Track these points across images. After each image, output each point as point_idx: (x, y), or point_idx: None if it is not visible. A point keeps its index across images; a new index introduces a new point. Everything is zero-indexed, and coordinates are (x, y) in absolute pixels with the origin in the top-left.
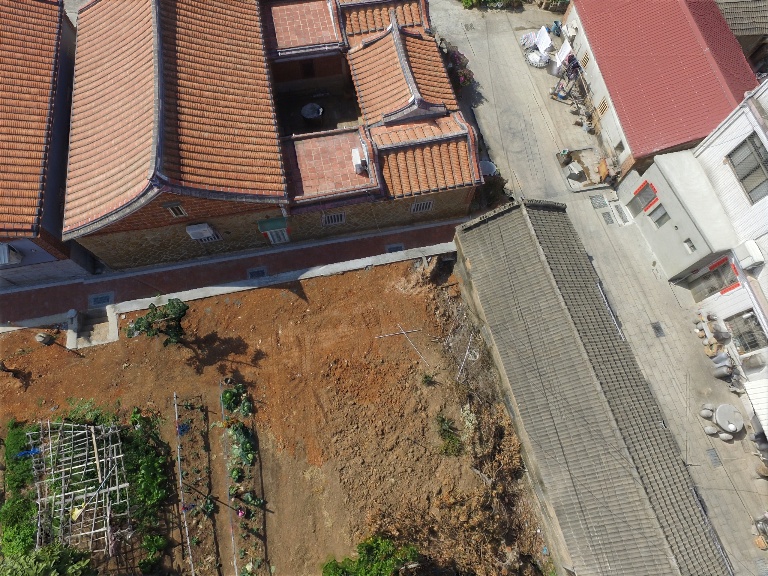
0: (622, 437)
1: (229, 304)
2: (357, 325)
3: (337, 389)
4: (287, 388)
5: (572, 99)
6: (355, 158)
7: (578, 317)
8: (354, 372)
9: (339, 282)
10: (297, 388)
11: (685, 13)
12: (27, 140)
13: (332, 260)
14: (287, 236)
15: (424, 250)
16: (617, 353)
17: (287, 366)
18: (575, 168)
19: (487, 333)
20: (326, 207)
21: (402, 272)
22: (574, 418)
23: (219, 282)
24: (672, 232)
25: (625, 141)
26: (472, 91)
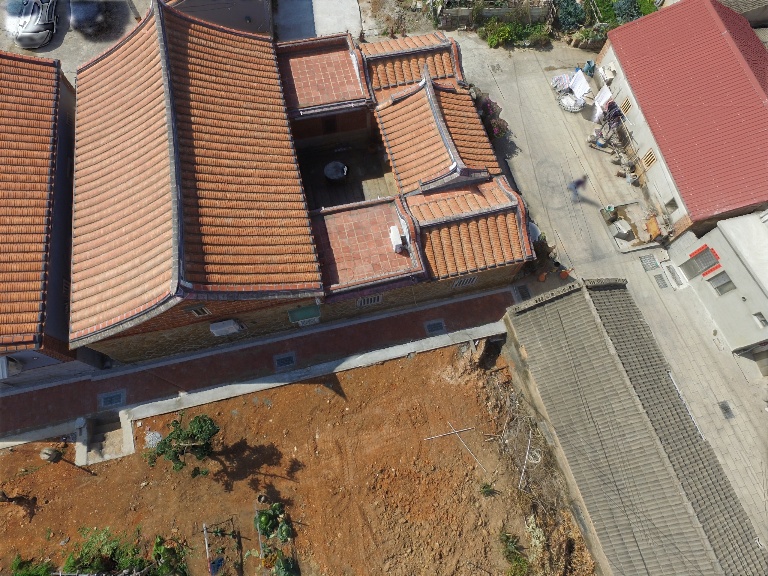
0: (723, 572)
1: (258, 405)
2: (403, 425)
3: (385, 504)
4: (329, 505)
5: (612, 147)
6: (395, 237)
7: (657, 420)
8: (403, 483)
9: (379, 373)
10: (340, 505)
11: (739, 59)
12: (25, 230)
13: (367, 342)
14: (317, 318)
15: (471, 332)
16: (701, 459)
17: (327, 478)
18: (623, 227)
19: (548, 431)
20: (364, 293)
21: (448, 359)
22: (663, 544)
23: (243, 373)
24: (738, 302)
25: (679, 199)
26: (505, 140)
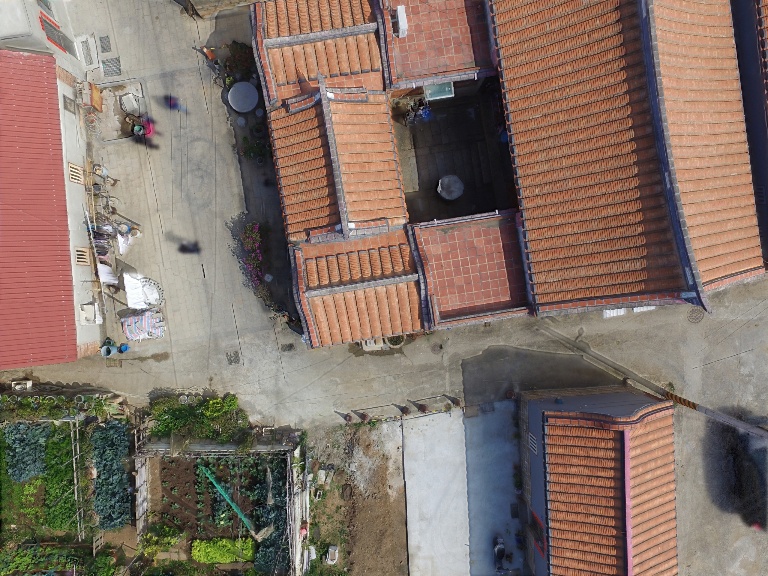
0: None
1: None
2: None
3: None
4: None
5: None
6: (404, 14)
7: None
8: None
9: None
10: None
11: None
12: None
13: None
14: None
15: None
16: None
17: None
18: (131, 100)
19: None
20: None
21: None
22: None
23: None
24: None
25: (60, 99)
26: None
